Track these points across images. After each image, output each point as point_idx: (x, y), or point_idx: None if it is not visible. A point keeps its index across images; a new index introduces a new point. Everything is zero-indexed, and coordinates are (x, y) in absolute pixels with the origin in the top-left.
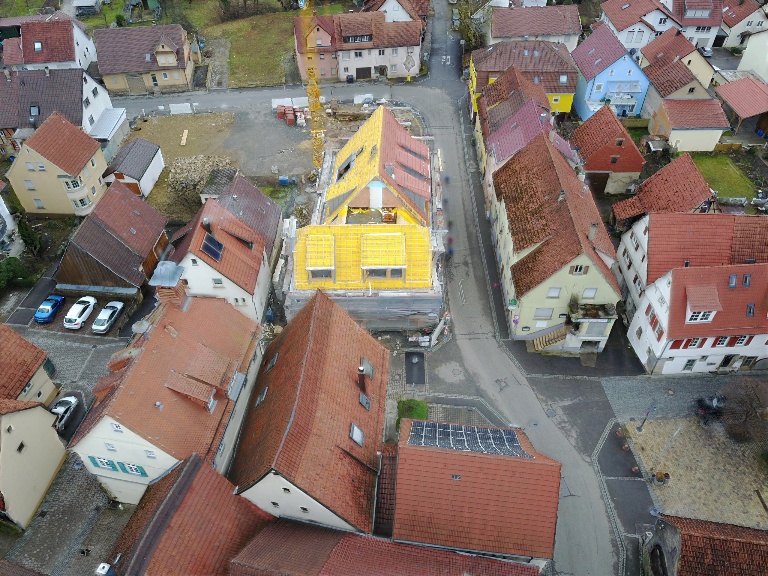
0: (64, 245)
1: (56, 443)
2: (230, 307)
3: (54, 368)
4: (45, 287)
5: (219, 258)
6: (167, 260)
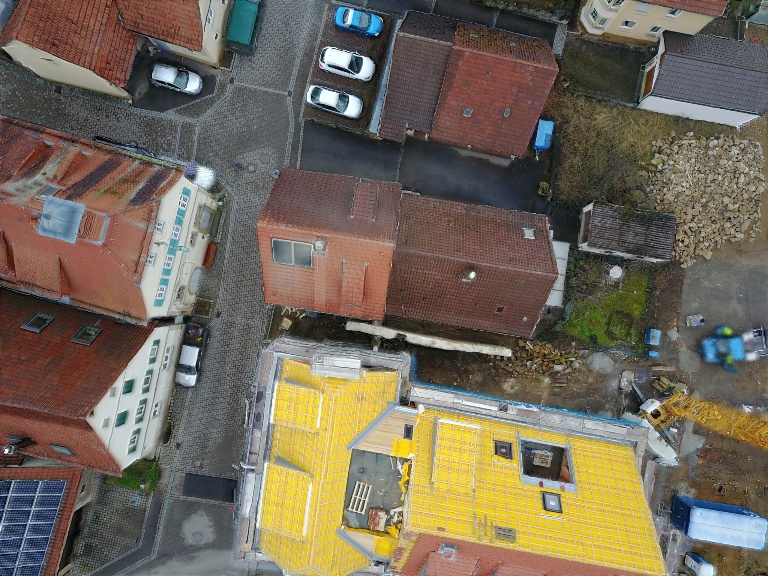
0: (508, 7)
1: (109, 87)
2: (137, 289)
3: (252, 53)
4: (412, 3)
5: (283, 262)
6: (357, 178)
